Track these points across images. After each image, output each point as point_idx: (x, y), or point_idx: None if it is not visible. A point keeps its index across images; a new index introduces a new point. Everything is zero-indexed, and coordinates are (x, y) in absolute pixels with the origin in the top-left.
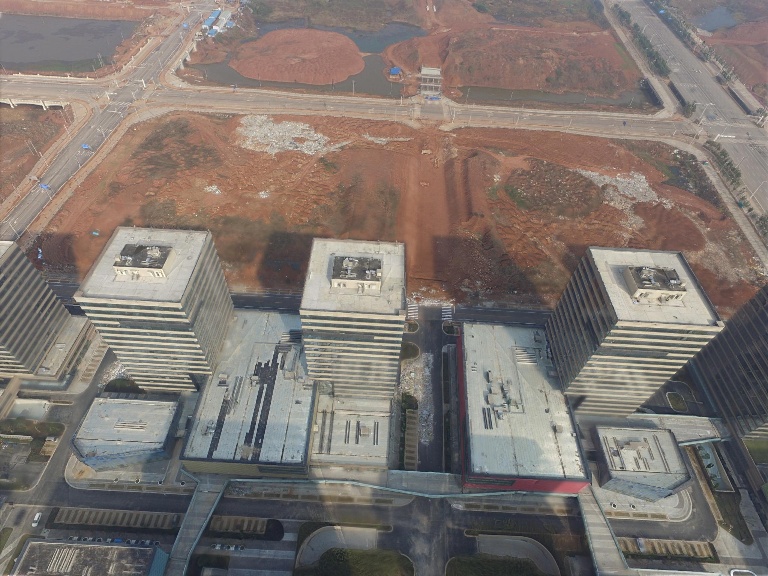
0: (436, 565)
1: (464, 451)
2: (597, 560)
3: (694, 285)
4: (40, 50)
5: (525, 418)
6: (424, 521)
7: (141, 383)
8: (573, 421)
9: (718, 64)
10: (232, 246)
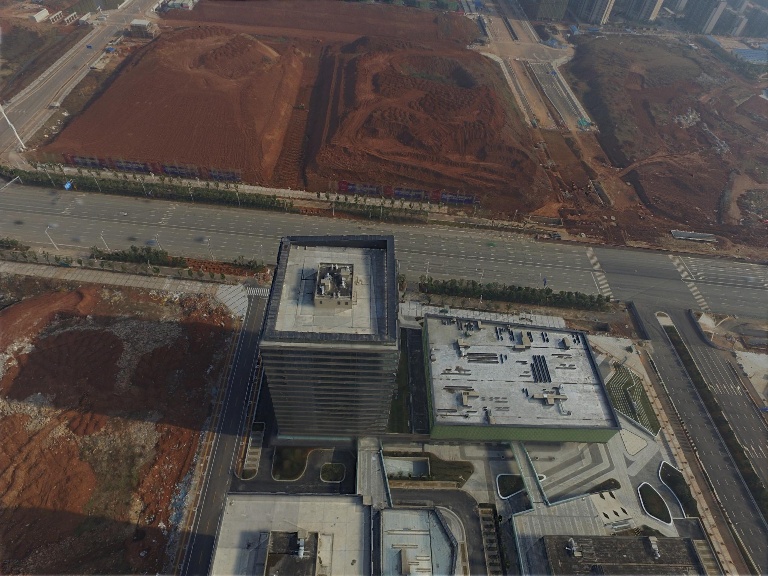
0: None
1: None
2: None
3: (292, 500)
4: None
5: None
6: None
7: None
8: None
9: None
10: None
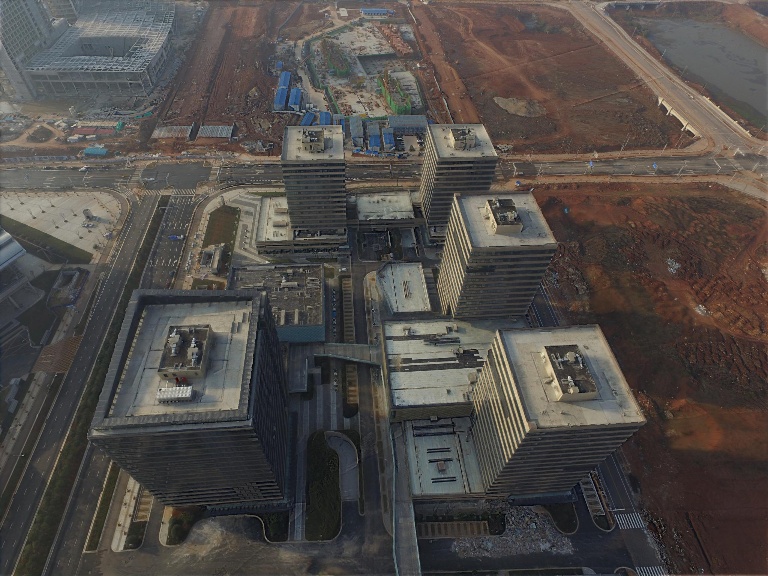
0: (335, 565)
1: None
2: None
3: None
4: (756, 95)
5: None
6: (373, 549)
7: None
8: None
9: None
10: (610, 303)
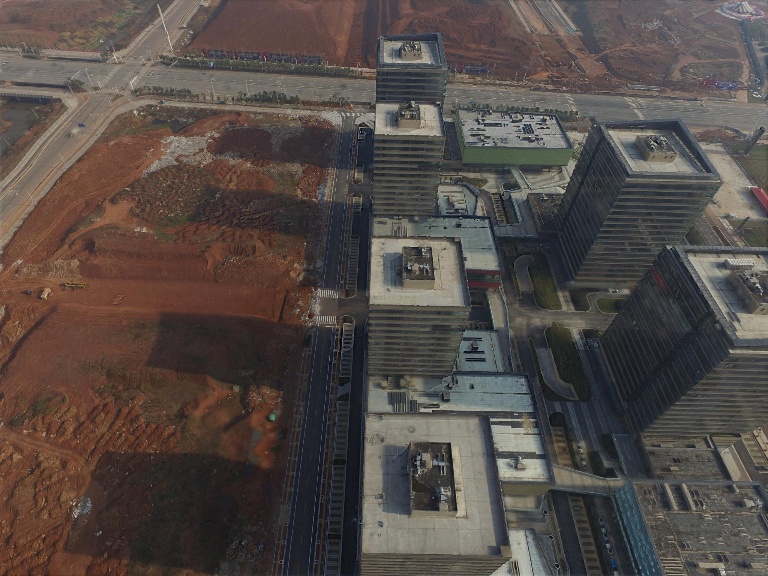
0: (544, 315)
1: (478, 281)
2: (520, 235)
3: None
4: None
5: None
6: (519, 320)
7: None
8: (452, 216)
9: (2, 49)
10: (202, 539)
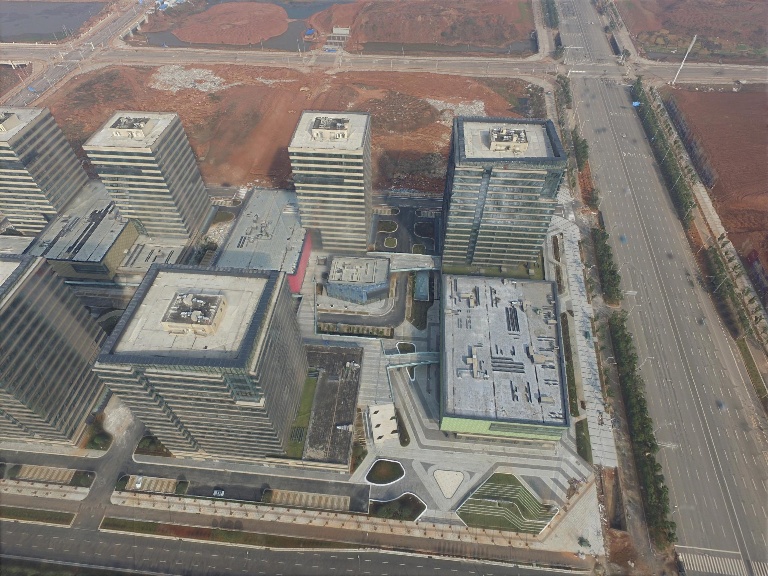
0: None
1: None
2: None
3: None
4: (23, 27)
5: (270, 242)
6: None
7: (16, 225)
8: (303, 244)
9: (613, 16)
10: None
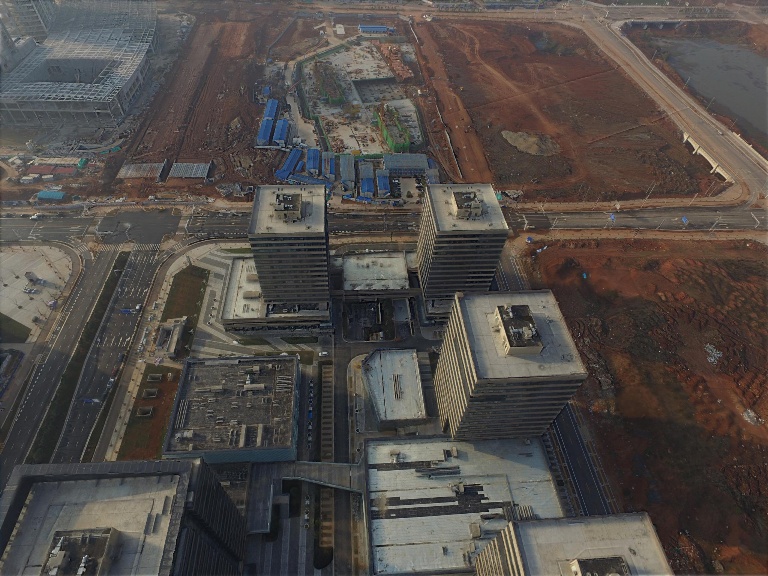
0: None
1: None
2: None
3: None
4: None
5: None
6: None
7: (436, 378)
8: None
9: None
10: (640, 405)
